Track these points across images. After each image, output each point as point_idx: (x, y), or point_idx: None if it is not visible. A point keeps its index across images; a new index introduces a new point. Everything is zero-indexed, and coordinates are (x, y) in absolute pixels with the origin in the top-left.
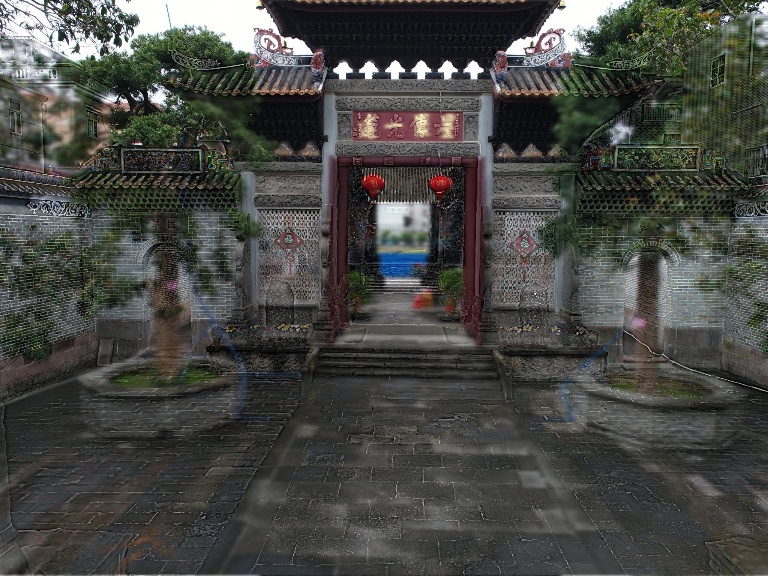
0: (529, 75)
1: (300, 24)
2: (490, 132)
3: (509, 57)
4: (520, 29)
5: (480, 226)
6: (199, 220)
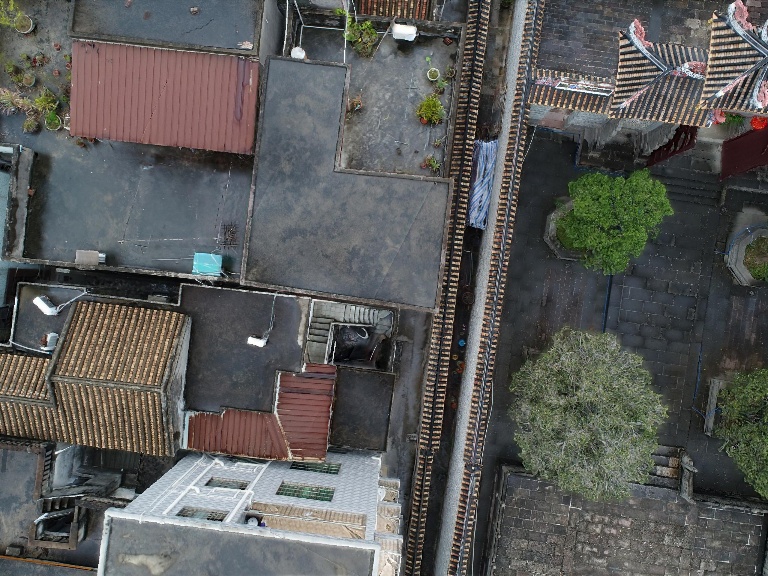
0: None
1: None
2: None
3: None
4: None
5: None
6: None
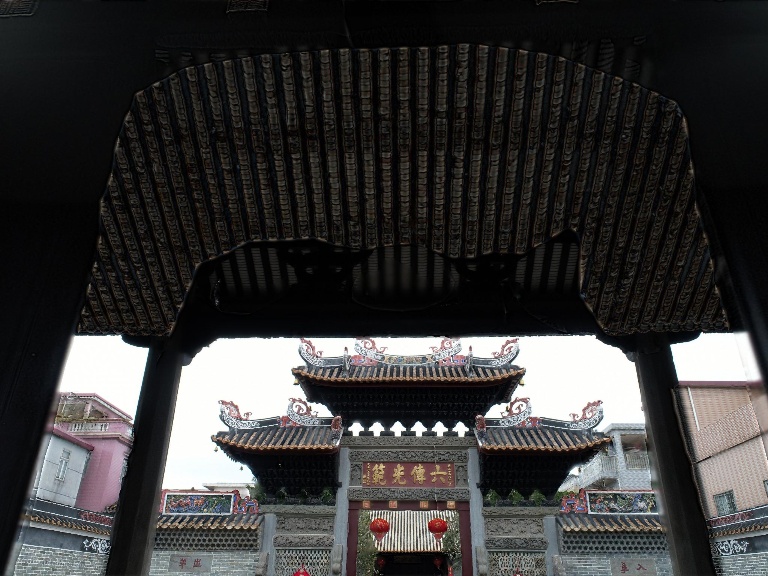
0: (505, 433)
1: (325, 395)
2: (478, 479)
3: (488, 419)
4: (494, 399)
5: (476, 566)
6: (222, 559)
